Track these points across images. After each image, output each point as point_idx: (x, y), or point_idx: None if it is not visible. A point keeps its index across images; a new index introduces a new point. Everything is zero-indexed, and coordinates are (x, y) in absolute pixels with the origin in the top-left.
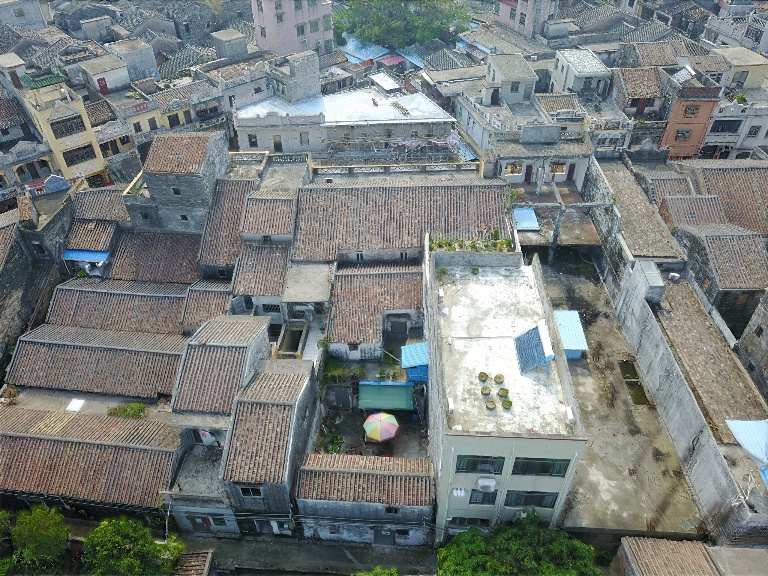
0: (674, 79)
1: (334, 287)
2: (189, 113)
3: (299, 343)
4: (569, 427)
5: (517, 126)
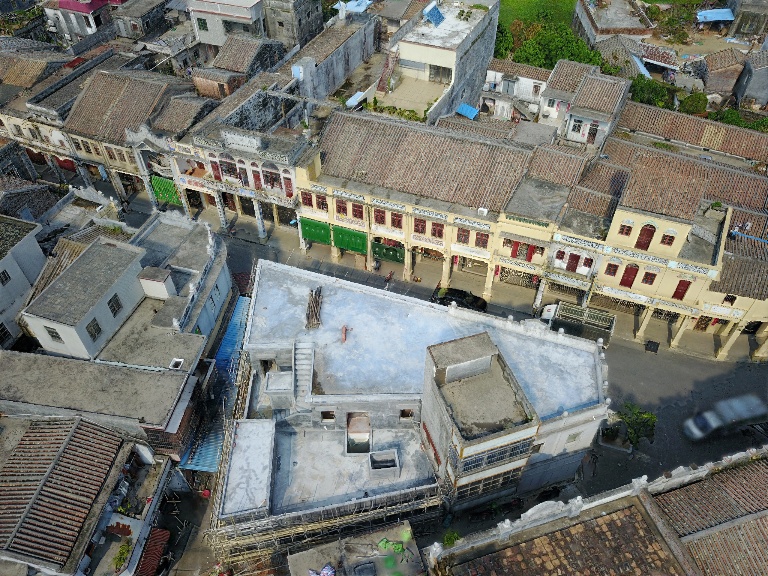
0: None
1: None
2: None
3: None
4: (440, 5)
5: None
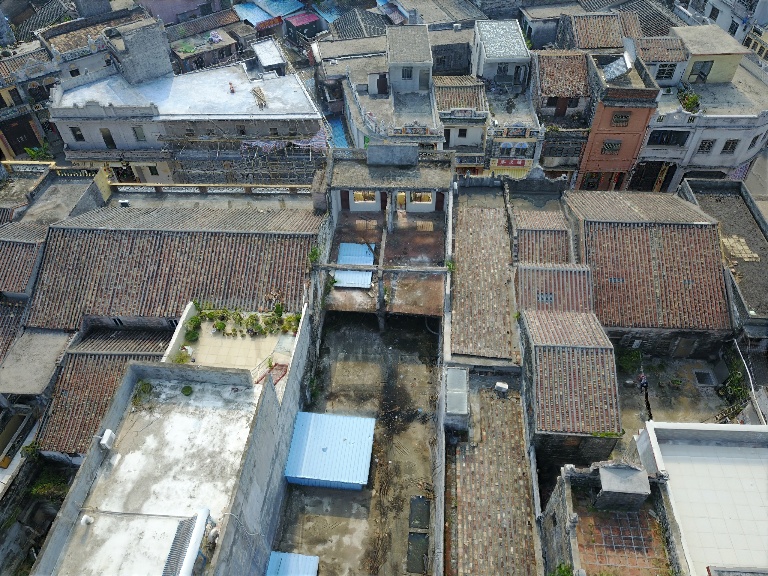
0: (601, 74)
1: (62, 370)
2: (17, 92)
3: (8, 443)
4: None
5: (393, 129)
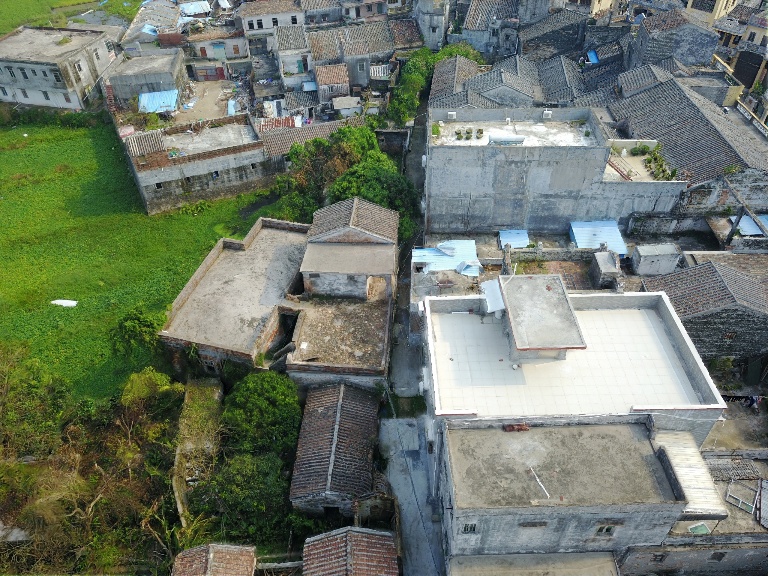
0: None
1: None
2: None
3: None
4: None
5: None
